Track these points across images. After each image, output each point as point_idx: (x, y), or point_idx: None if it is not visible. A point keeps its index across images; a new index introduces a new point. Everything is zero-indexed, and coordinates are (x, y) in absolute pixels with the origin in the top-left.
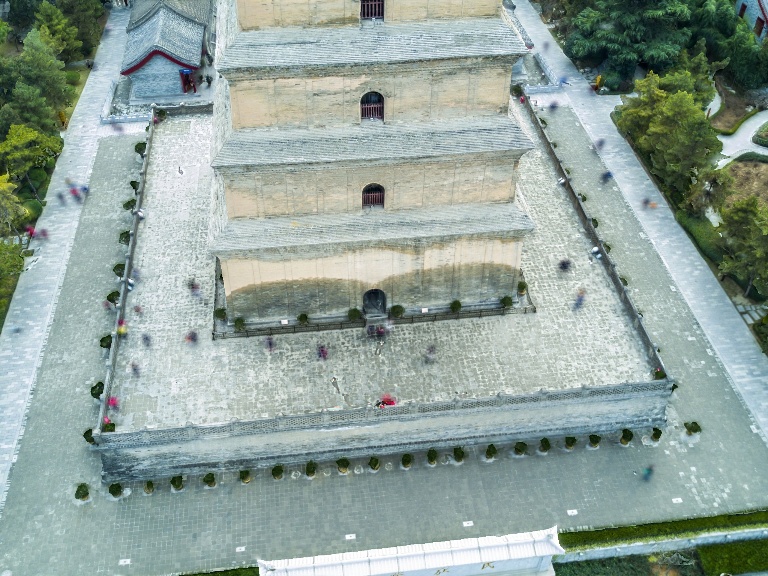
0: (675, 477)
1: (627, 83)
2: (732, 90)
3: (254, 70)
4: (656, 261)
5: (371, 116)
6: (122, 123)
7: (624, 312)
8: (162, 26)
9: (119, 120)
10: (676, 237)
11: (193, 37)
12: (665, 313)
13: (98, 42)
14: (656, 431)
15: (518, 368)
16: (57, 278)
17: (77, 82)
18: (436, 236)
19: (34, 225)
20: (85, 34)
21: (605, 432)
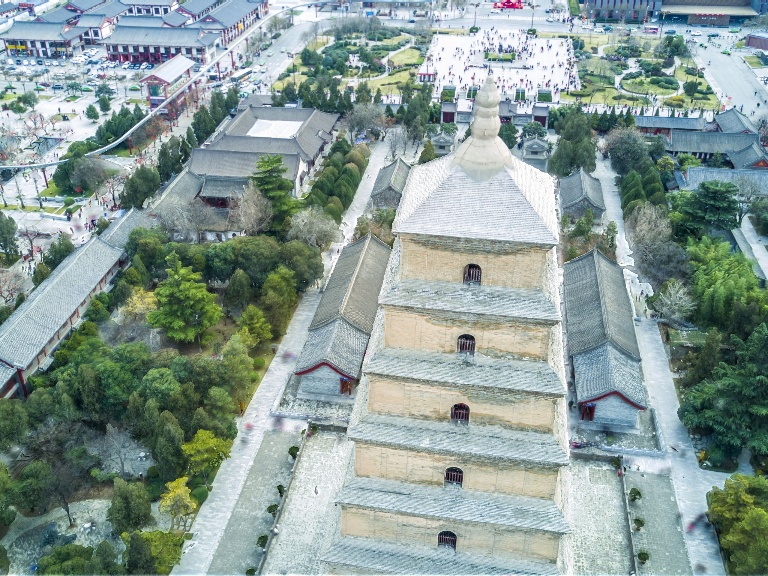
0: None
1: (731, 461)
2: None
3: (360, 505)
4: None
5: (447, 543)
6: (286, 418)
7: None
8: (335, 338)
9: (284, 415)
10: None
11: (358, 347)
12: None
13: (285, 333)
14: None
15: None
16: (204, 567)
17: (262, 367)
18: None
19: (199, 509)
20: (277, 326)
21: None
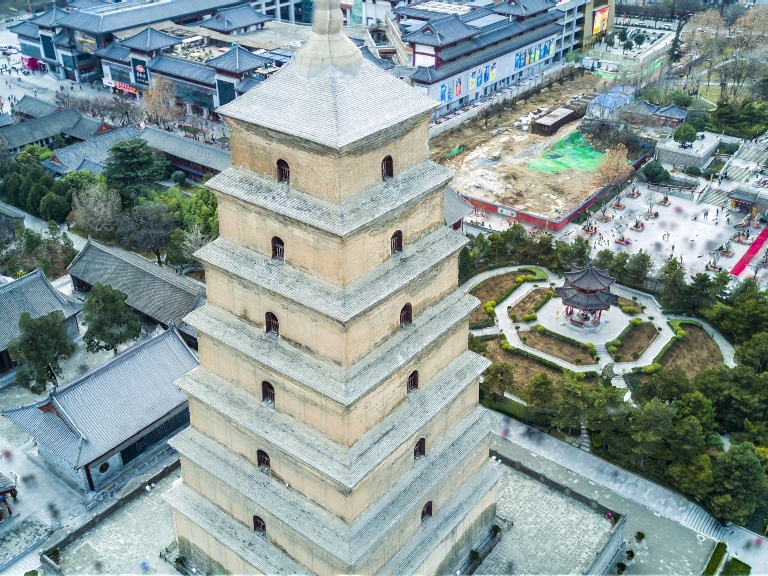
0: (661, 573)
1: None
2: None
3: None
4: (507, 443)
5: (415, 456)
6: None
7: (552, 490)
8: None
9: None
10: None
11: None
12: (548, 474)
13: None
14: (630, 553)
15: (548, 570)
16: None
17: None
18: None
19: None
20: None
21: (607, 575)
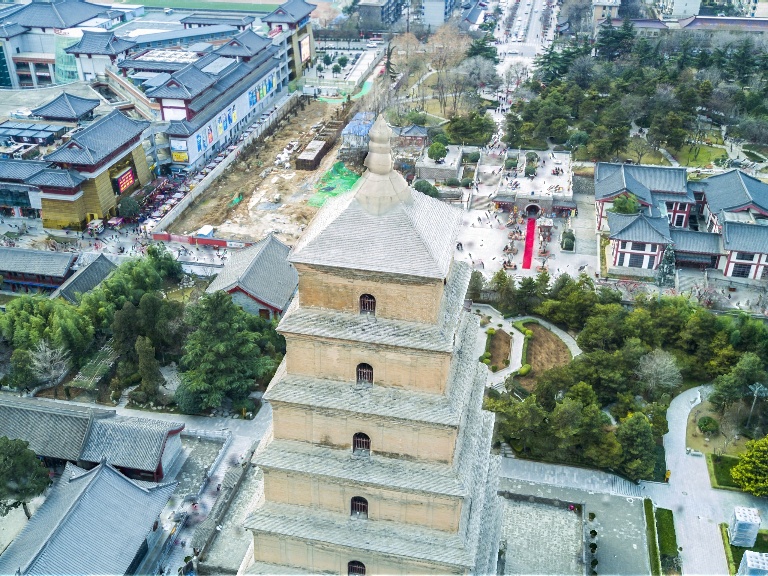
0: (620, 540)
1: None
2: None
3: None
4: None
5: None
6: None
7: (517, 502)
8: None
9: None
10: None
11: None
12: None
13: None
14: (594, 532)
15: (554, 571)
16: None
17: None
18: None
19: None
20: None
21: None
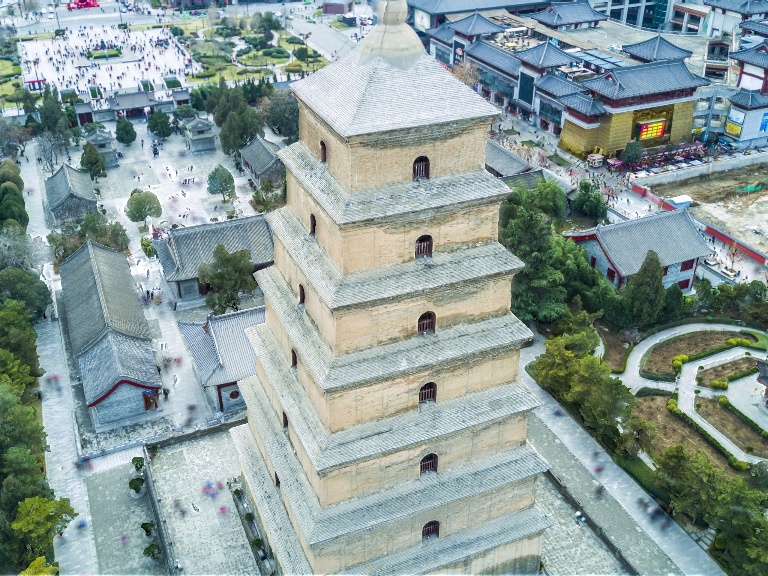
0: None
1: None
2: (605, 329)
3: None
4: (616, 506)
5: (426, 470)
6: (101, 457)
7: (623, 570)
8: (118, 353)
9: (97, 454)
10: (621, 479)
11: (145, 355)
12: (642, 555)
13: (44, 371)
14: None
15: None
16: None
17: None
18: (482, 550)
19: None
20: (32, 367)
21: None
